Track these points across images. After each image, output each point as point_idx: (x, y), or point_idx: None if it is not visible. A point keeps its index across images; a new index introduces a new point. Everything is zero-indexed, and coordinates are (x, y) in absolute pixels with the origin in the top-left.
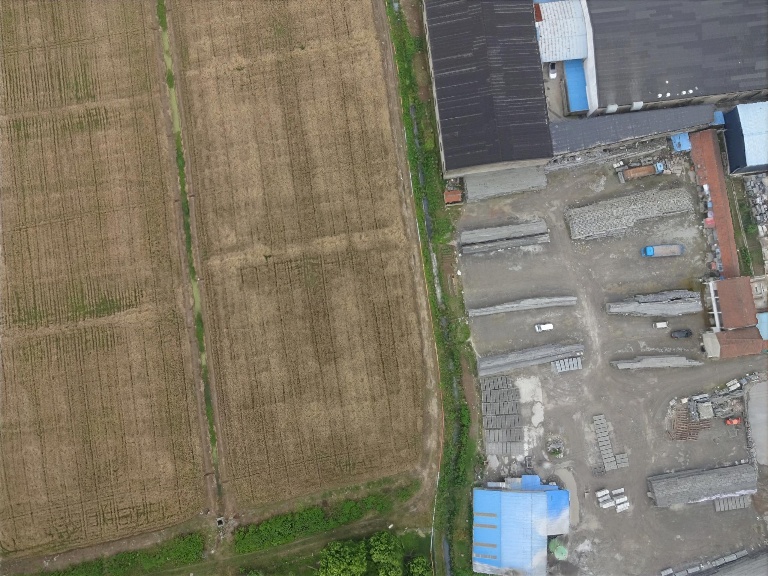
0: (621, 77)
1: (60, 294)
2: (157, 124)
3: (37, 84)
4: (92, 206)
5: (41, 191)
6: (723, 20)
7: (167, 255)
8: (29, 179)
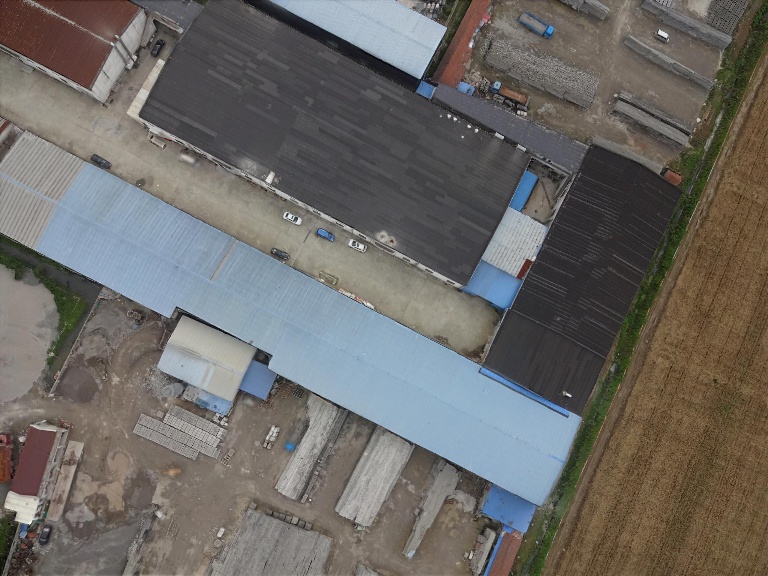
0: (499, 166)
1: None
2: None
3: None
4: None
5: None
6: (385, 151)
7: None
8: None
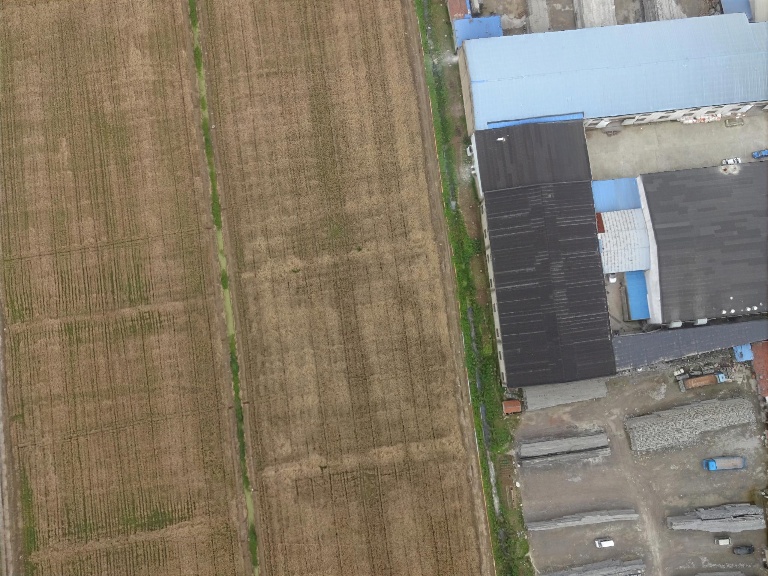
0: (685, 293)
1: (111, 506)
2: (211, 328)
3: (89, 286)
4: (144, 414)
5: (93, 398)
6: None
7: (221, 465)
8: (80, 385)
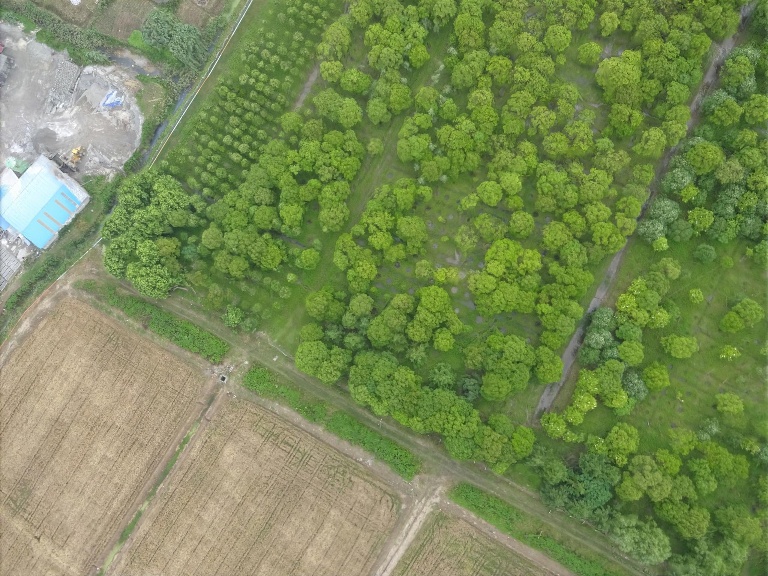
0: None
1: None
2: None
3: None
4: None
5: None
6: None
7: None
8: None
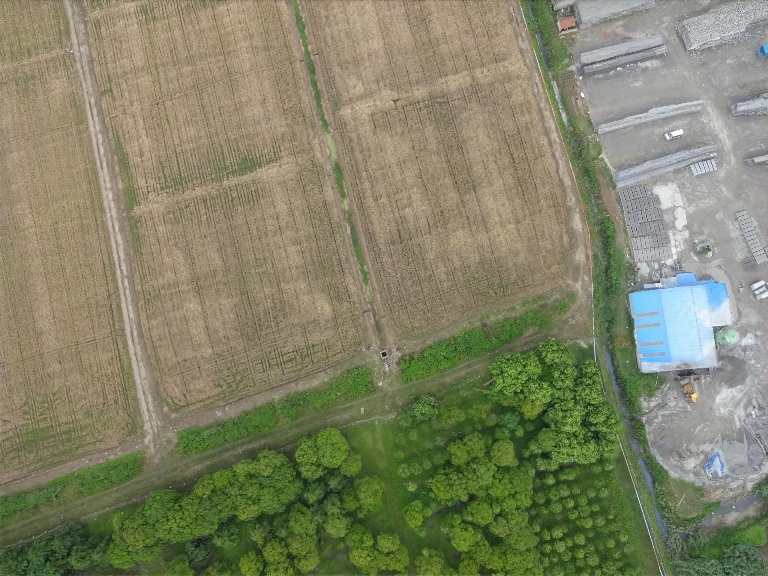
0: None
1: (202, 158)
2: None
3: None
4: (223, 74)
5: (173, 66)
6: None
7: (299, 111)
8: (161, 57)
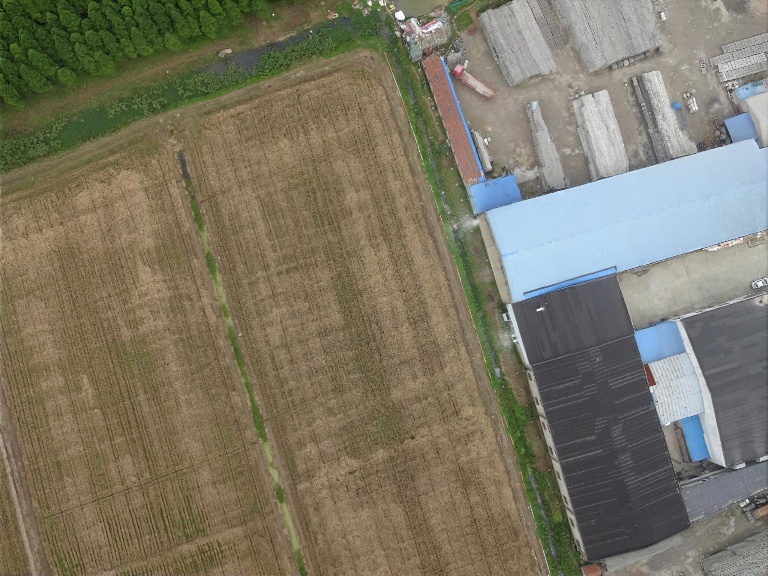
0: (743, 434)
1: None
2: (276, 548)
3: (140, 528)
4: None
5: None
6: None
7: None
8: None
